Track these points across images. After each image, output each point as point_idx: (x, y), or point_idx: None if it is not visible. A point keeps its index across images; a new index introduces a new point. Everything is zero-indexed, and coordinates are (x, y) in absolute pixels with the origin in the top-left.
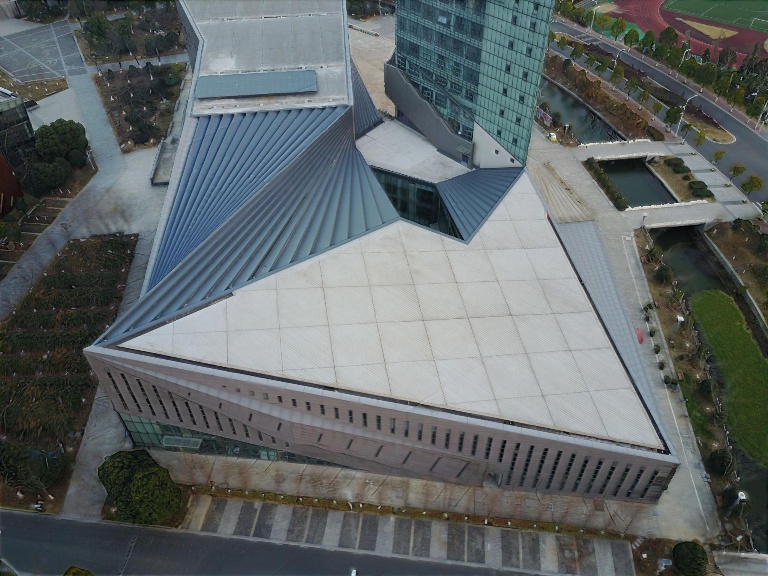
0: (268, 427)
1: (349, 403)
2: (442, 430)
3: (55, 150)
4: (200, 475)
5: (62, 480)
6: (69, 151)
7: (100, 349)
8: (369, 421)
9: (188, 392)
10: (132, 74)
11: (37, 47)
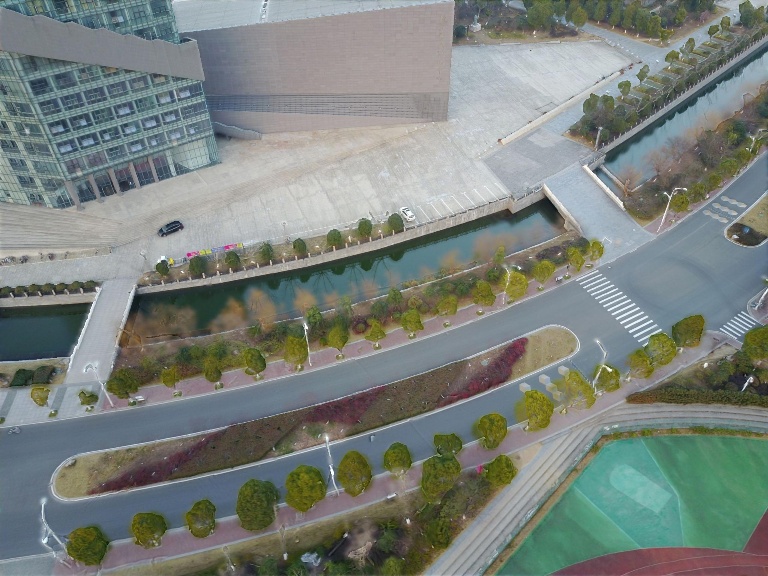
0: None
1: None
2: None
3: None
4: None
5: None
6: None
7: None
8: None
9: None
10: None
11: None
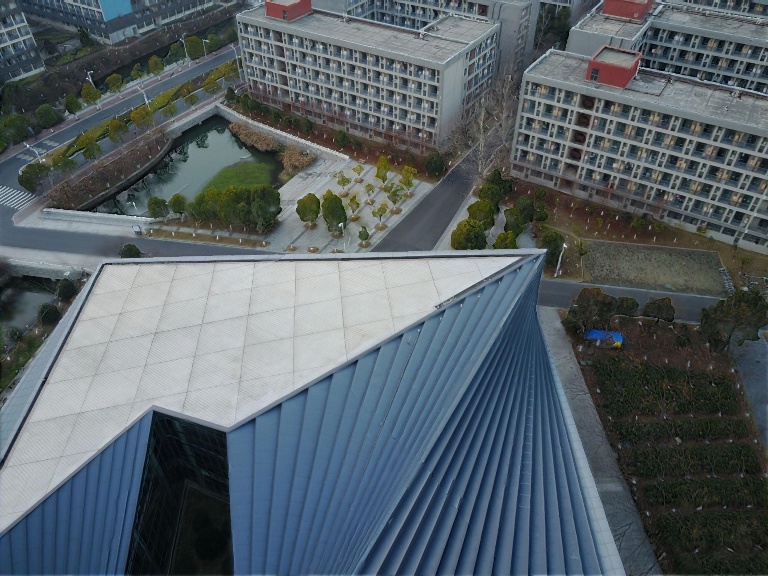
0: None
1: None
2: None
3: None
4: None
5: None
6: None
7: (533, 252)
8: None
9: None
10: None
11: None
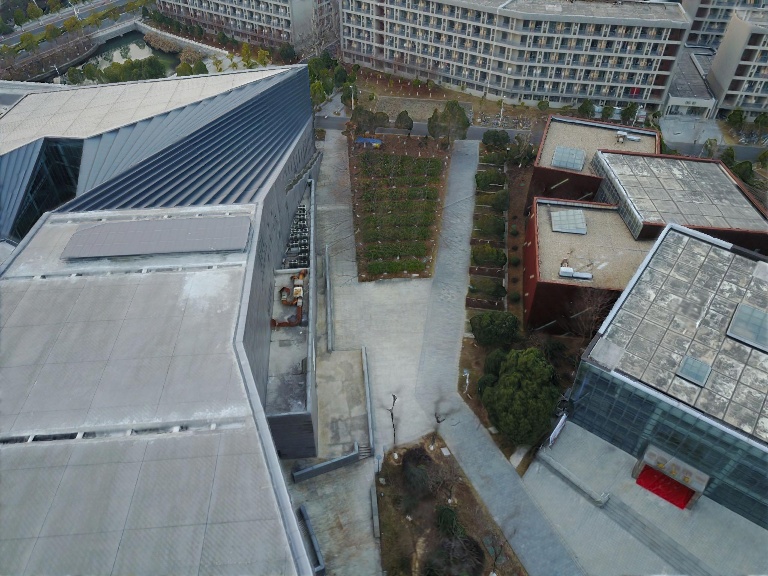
0: None
1: None
2: None
3: None
4: None
5: None
6: None
7: (299, 65)
8: None
9: None
10: None
11: None
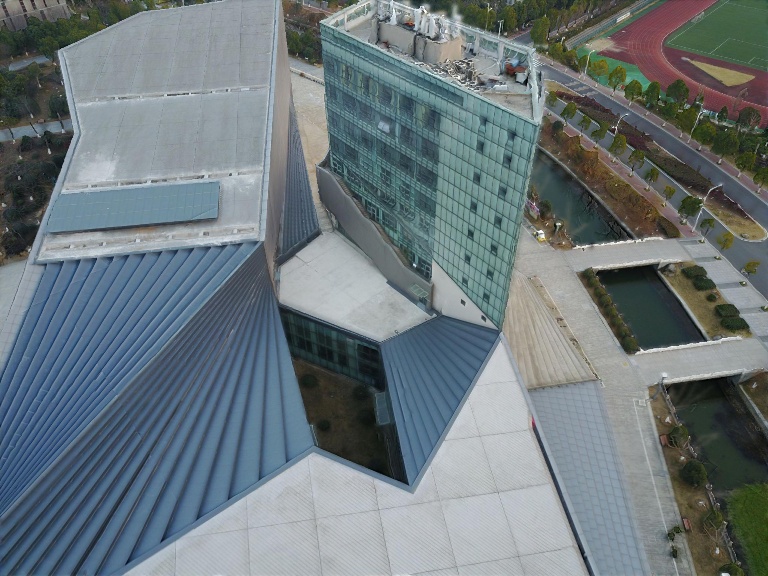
0: None
1: None
2: None
3: None
4: None
5: None
6: None
7: None
8: None
9: None
10: (26, 146)
11: None
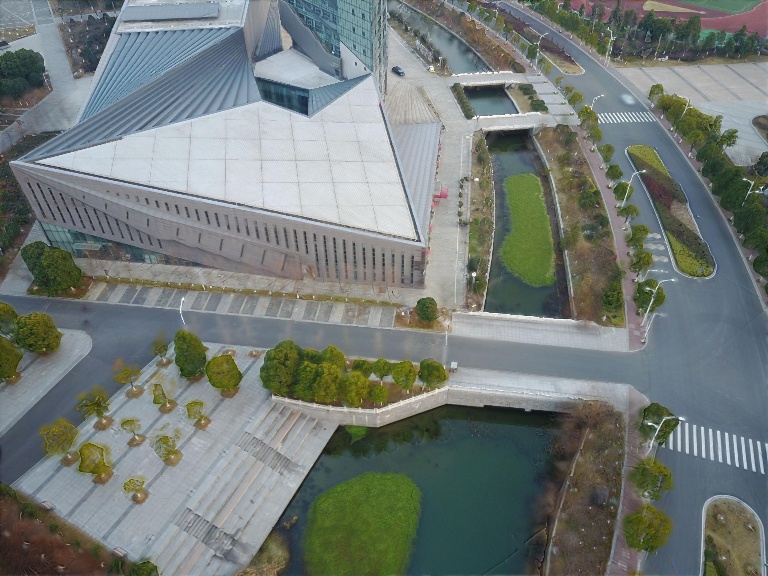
0: (141, 224)
1: (193, 202)
2: (261, 224)
3: (17, 71)
4: (100, 272)
5: (1, 273)
6: (29, 74)
7: (21, 163)
8: (210, 219)
9: (83, 195)
10: (91, 23)
11: (13, 3)
